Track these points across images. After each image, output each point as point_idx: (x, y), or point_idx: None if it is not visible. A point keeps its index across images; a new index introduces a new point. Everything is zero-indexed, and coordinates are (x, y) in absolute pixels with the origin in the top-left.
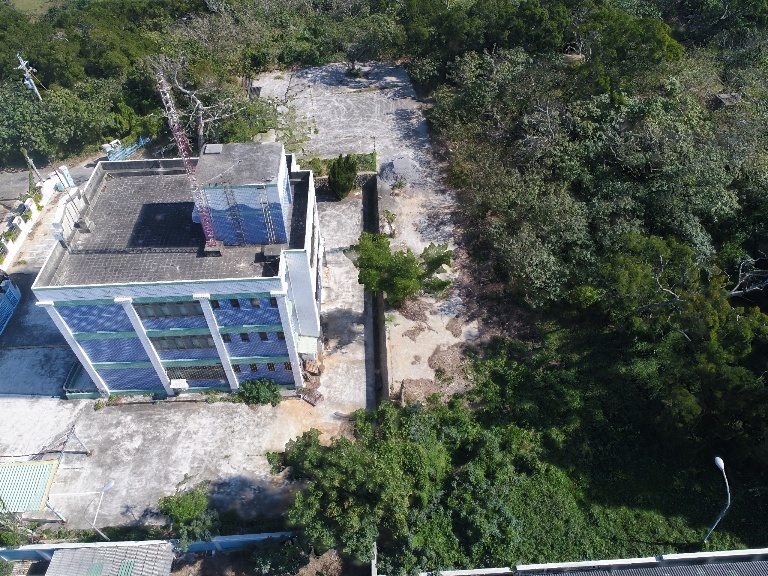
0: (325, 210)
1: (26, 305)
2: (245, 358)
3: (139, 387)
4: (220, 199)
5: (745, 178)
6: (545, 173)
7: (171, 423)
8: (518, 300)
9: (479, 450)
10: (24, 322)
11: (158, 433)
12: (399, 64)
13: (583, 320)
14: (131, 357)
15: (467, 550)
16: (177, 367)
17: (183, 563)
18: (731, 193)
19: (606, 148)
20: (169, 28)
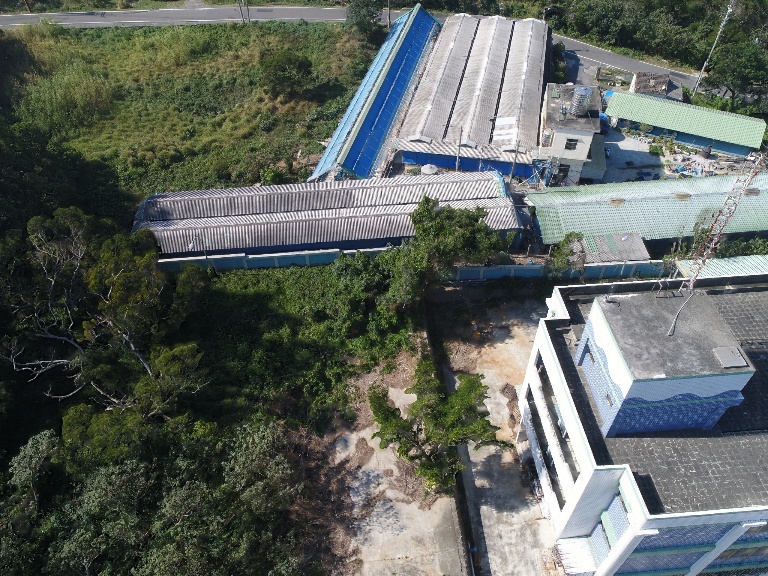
0: None
1: None
2: None
3: None
4: None
5: None
6: None
7: None
8: None
9: None
10: None
11: None
12: None
13: None
14: None
15: None
16: None
17: None
18: None
19: None
20: None
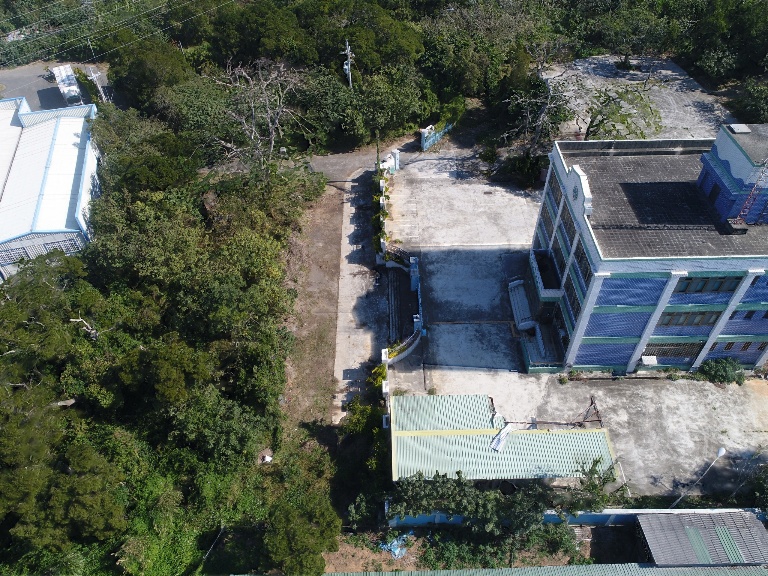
0: None
1: (426, 282)
2: (732, 336)
3: (602, 363)
4: None
5: None
6: None
7: (646, 399)
8: None
9: None
10: (435, 298)
11: (639, 408)
12: (665, 58)
13: None
14: (623, 332)
15: None
16: (659, 343)
17: None
18: None
19: None
20: (429, 18)
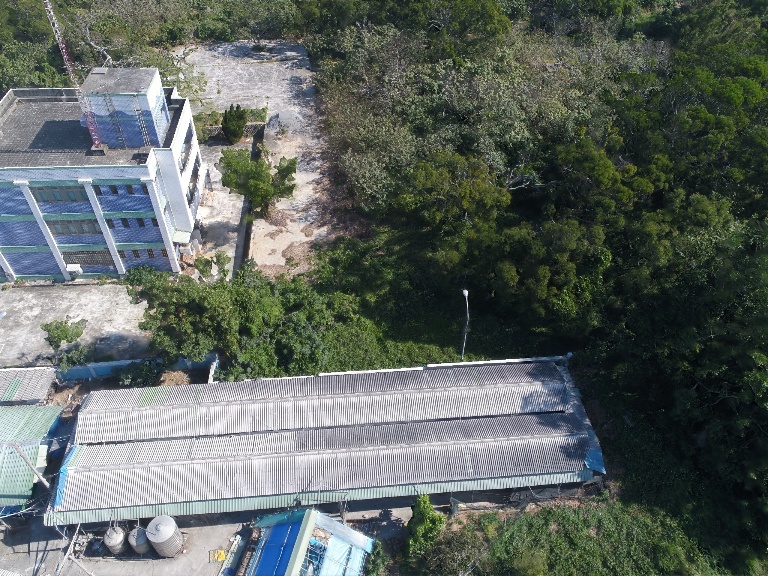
0: (219, 152)
1: None
2: (128, 244)
3: (41, 272)
4: (101, 106)
5: (541, 118)
6: (395, 118)
7: (66, 299)
8: (362, 211)
9: (303, 300)
10: None
11: (54, 305)
12: (300, 42)
13: (410, 224)
14: (32, 241)
15: (286, 369)
16: (71, 252)
17: (65, 387)
18: (522, 125)
19: (446, 100)
20: (95, 5)
